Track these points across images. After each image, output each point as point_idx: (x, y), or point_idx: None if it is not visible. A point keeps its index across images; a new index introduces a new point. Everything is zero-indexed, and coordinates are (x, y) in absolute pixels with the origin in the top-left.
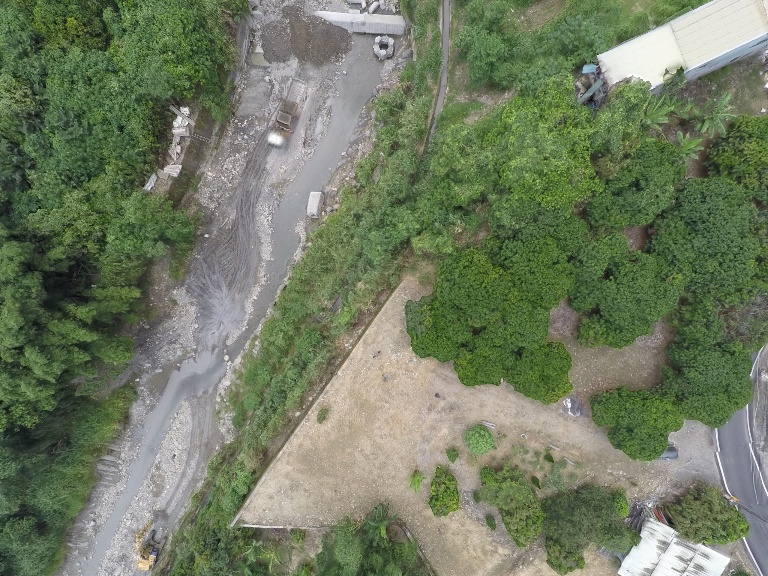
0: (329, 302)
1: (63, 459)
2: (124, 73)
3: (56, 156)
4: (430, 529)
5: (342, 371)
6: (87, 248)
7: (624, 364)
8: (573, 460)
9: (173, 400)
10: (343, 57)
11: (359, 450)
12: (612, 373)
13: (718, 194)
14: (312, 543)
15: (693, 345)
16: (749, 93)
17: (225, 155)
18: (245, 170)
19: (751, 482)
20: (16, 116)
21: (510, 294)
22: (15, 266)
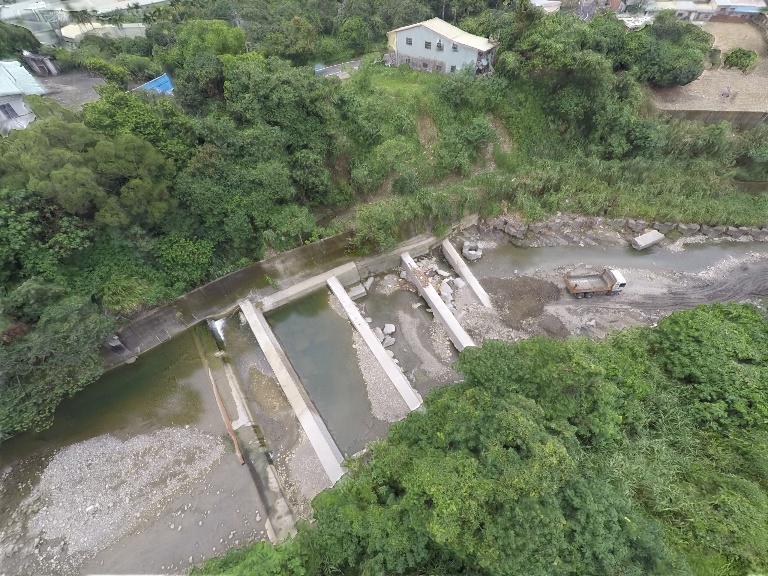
0: None
1: None
2: None
3: None
4: None
5: (760, 110)
6: None
7: None
8: None
9: None
10: None
11: None
12: None
13: None
14: None
15: None
16: None
17: None
18: None
19: None
20: None
21: None
22: None
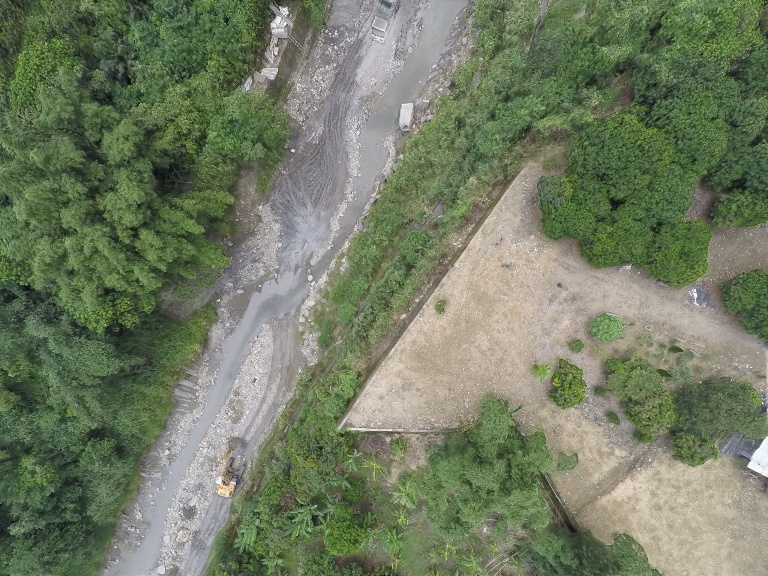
0: (428, 208)
1: (144, 379)
2: None
3: (162, 46)
4: (545, 430)
5: (459, 263)
6: (185, 148)
7: (752, 253)
8: (699, 353)
9: (253, 323)
10: None
11: (475, 346)
12: (739, 262)
13: None
14: (413, 454)
15: None
16: None
17: (315, 66)
18: (334, 83)
19: None
20: (125, 1)
21: (666, 152)
22: (131, 145)
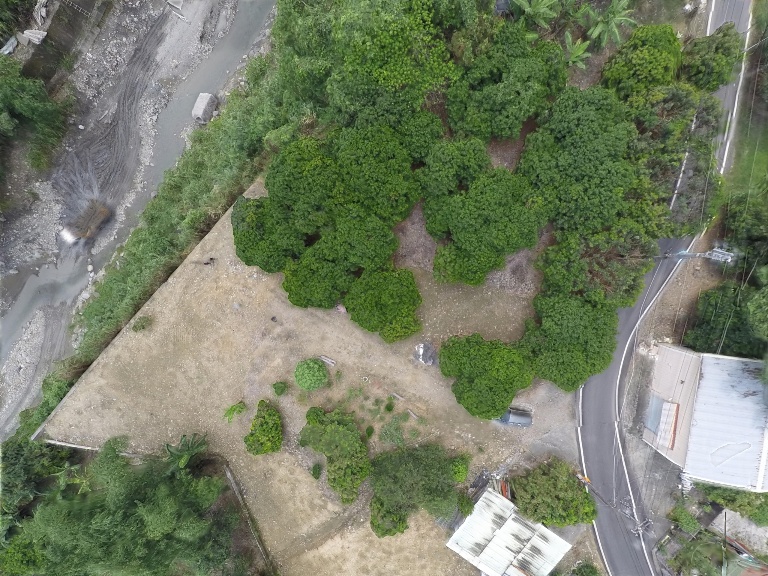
0: None
1: None
2: None
3: None
4: (255, 472)
5: (173, 278)
6: None
7: (489, 313)
8: (417, 414)
9: (29, 308)
10: None
11: (182, 371)
12: (474, 321)
13: (591, 103)
14: None
15: (556, 292)
16: (665, 13)
17: (109, 36)
18: (133, 59)
19: (612, 465)
20: None
21: (335, 189)
22: None
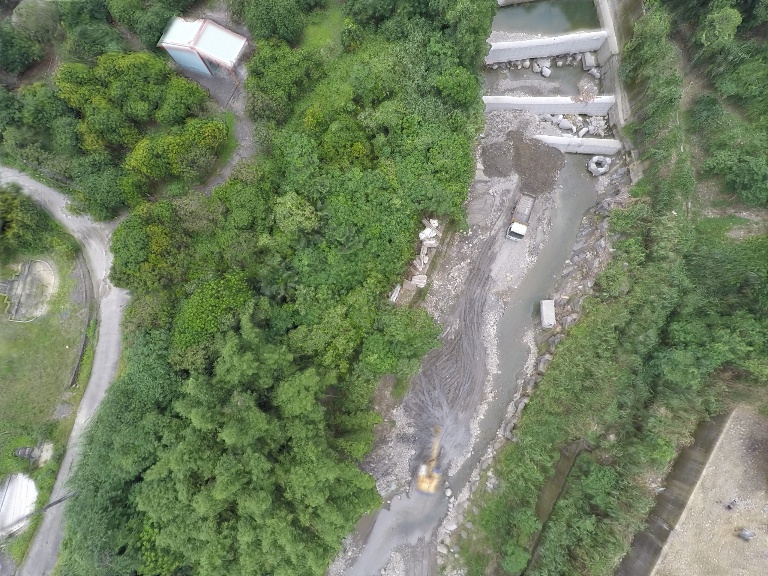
0: (599, 427)
1: None
2: (393, 190)
3: (328, 270)
4: None
5: (682, 525)
6: (338, 367)
7: None
8: None
9: (378, 549)
10: (558, 173)
11: None
12: None
13: None
14: None
15: None
16: None
17: (452, 263)
18: (468, 277)
19: None
20: (298, 231)
21: None
22: (313, 398)
